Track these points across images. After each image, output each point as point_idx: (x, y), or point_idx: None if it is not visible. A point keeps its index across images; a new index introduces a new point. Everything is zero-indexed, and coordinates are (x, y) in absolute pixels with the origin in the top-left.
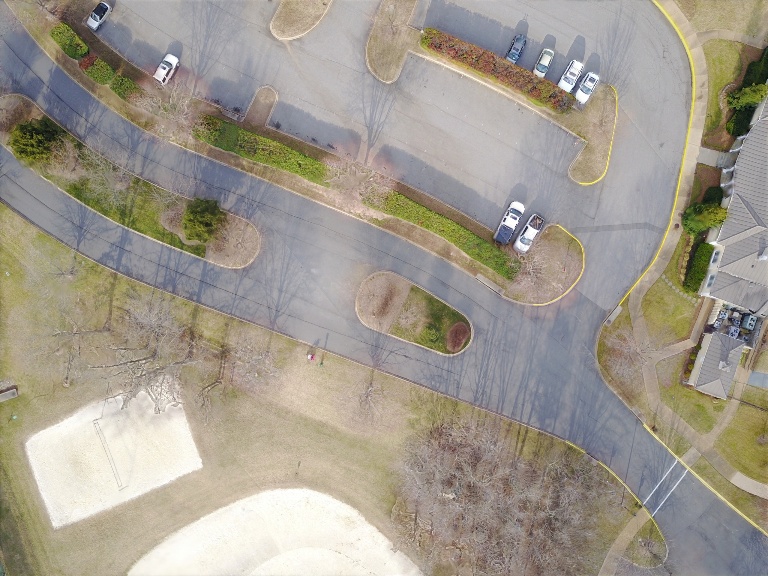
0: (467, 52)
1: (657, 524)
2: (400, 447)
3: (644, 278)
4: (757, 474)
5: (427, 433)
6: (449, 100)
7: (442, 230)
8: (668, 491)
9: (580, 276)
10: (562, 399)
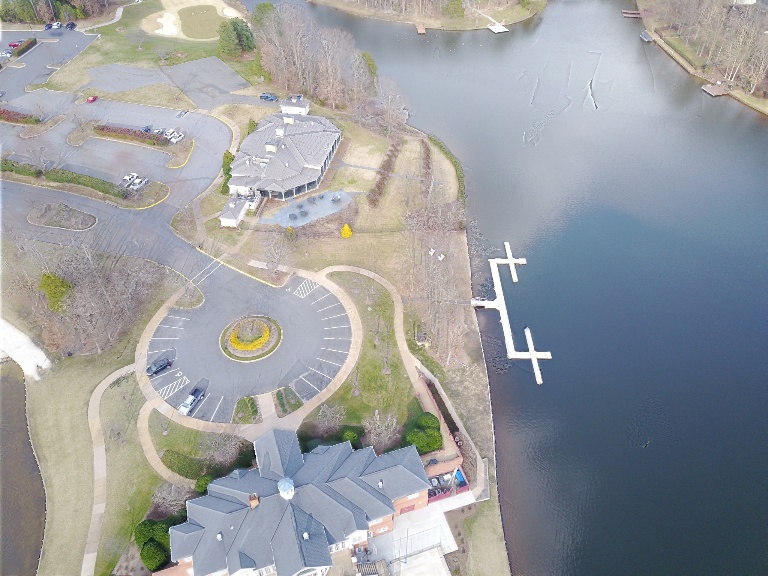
0: (116, 129)
1: (199, 288)
2: (37, 277)
3: (202, 195)
4: (264, 259)
5: (56, 266)
6: (107, 149)
7: (85, 180)
8: (208, 273)
9: (166, 197)
10: (147, 243)
